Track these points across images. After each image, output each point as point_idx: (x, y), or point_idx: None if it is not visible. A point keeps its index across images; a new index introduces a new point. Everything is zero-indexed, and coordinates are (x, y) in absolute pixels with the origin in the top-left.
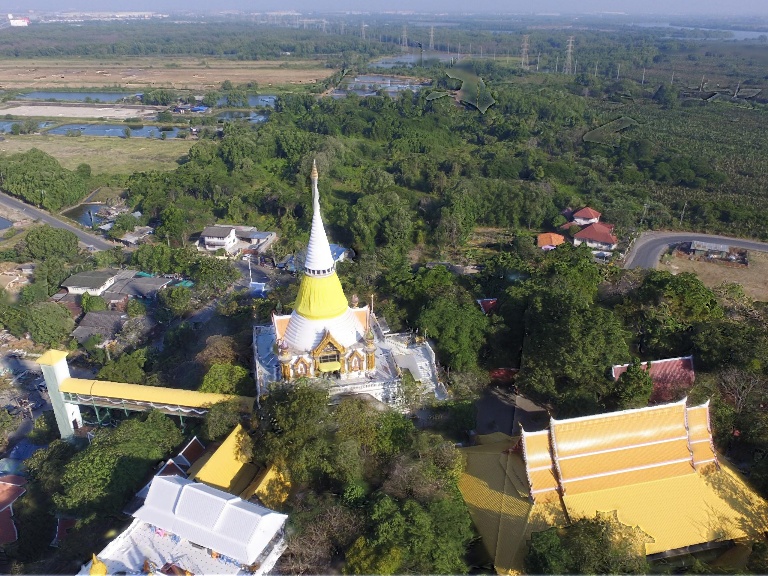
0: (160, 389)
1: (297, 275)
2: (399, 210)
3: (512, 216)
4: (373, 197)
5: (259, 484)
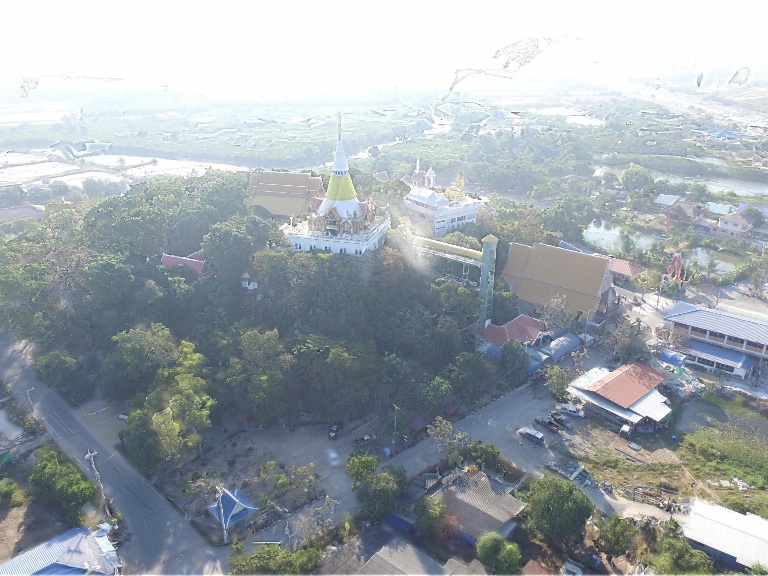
0: None
1: None
2: None
3: None
4: None
5: None
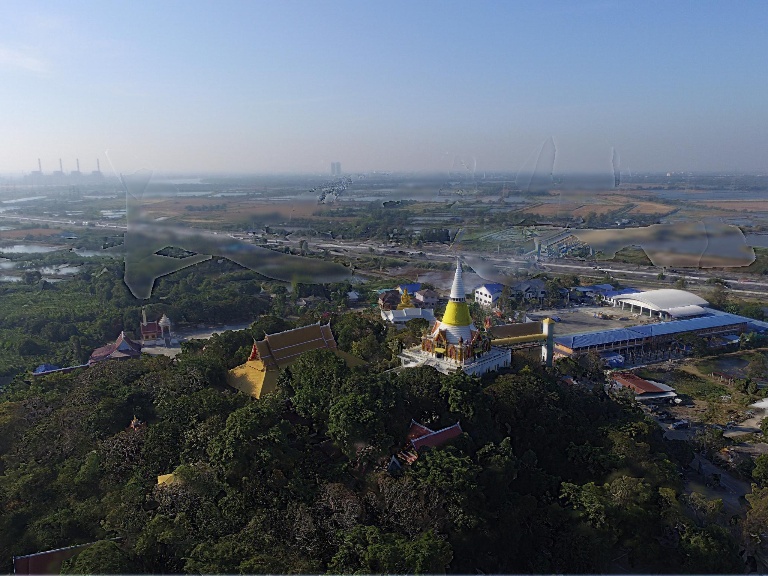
0: None
1: None
2: None
3: None
4: None
5: None
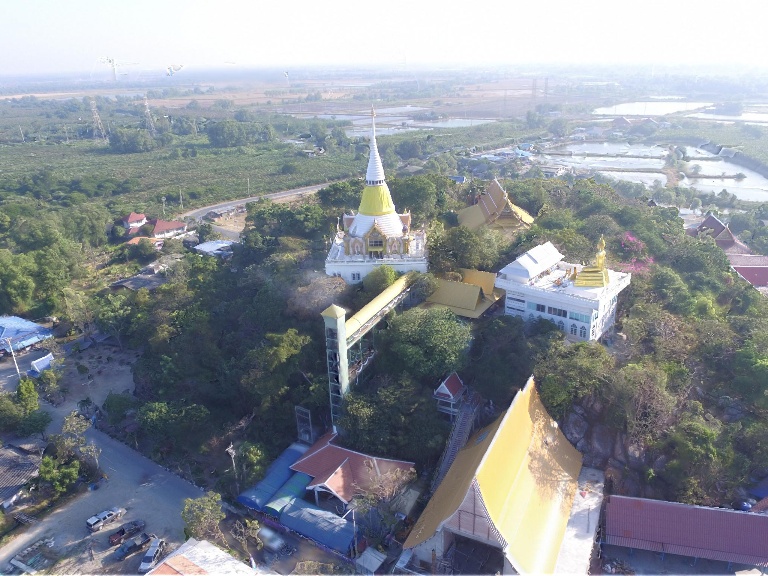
0: (380, 296)
1: (102, 315)
2: (49, 251)
3: (82, 241)
4: (4, 251)
5: (491, 273)
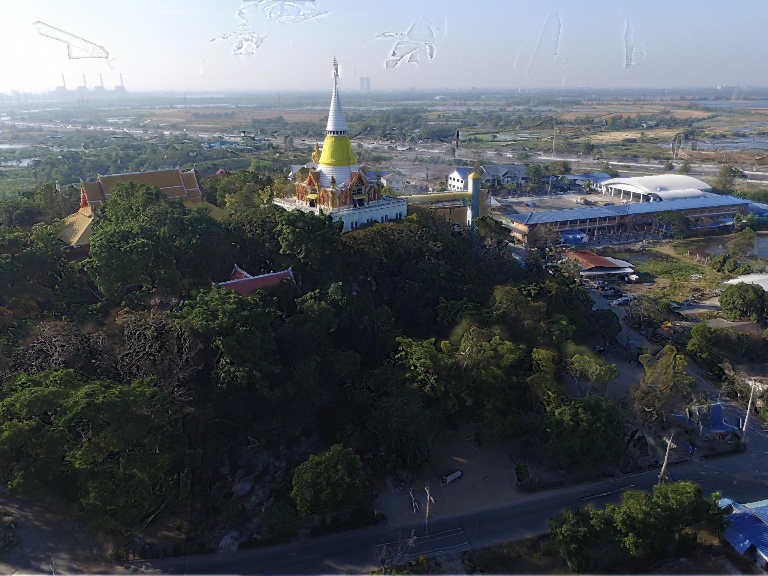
0: None
1: None
2: None
3: None
4: None
5: None
